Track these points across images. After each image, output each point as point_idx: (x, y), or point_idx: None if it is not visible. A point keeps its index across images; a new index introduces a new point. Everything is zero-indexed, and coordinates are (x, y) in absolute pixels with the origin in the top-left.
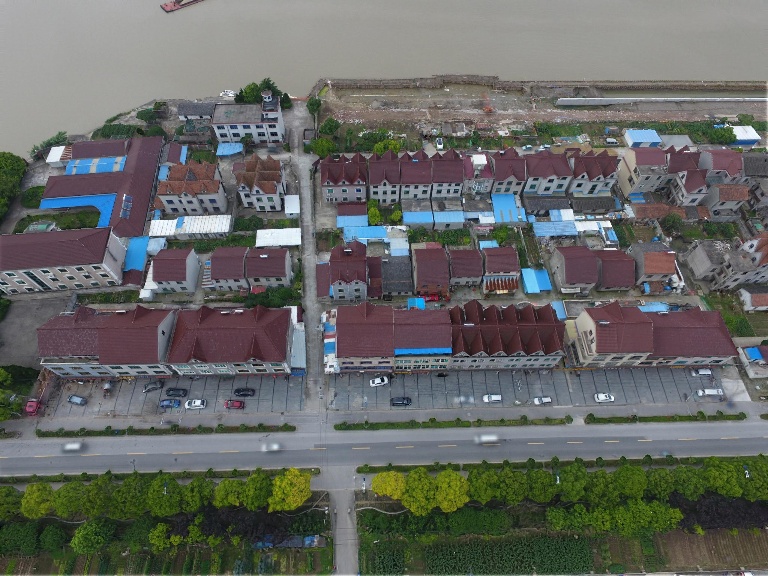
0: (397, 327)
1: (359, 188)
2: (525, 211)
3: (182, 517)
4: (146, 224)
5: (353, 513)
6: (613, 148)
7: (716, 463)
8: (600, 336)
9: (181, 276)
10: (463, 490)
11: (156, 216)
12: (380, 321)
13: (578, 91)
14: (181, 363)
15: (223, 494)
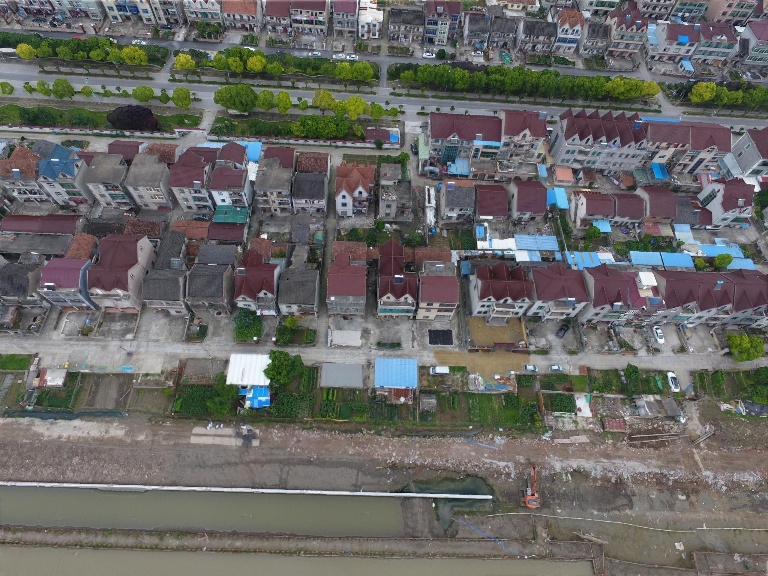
0: None
1: None
2: None
3: None
4: None
5: None
6: (438, 365)
7: (461, 81)
8: None
9: None
10: None
11: None
12: (701, 130)
13: (446, 536)
14: None
15: None
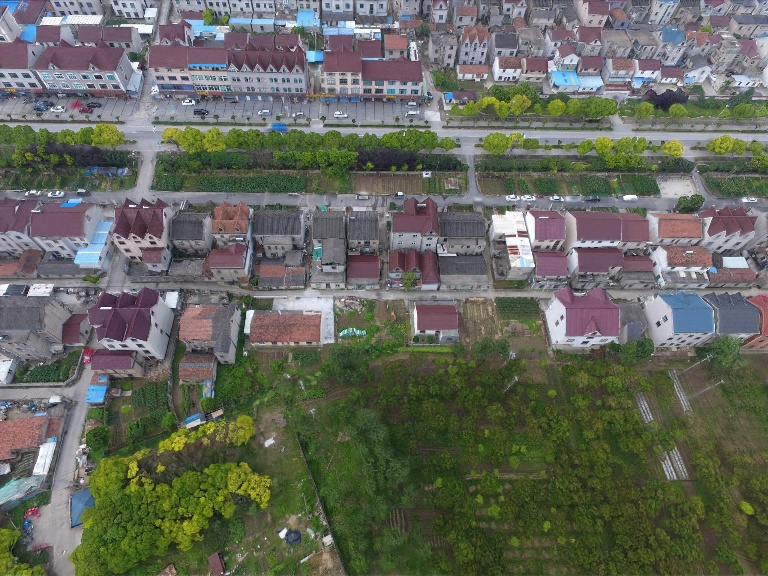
0: (190, 50)
1: (198, 0)
2: (322, 23)
3: (34, 144)
4: (39, 18)
5: (154, 161)
6: None
7: None
8: (326, 61)
9: (56, 39)
10: (221, 139)
11: (48, 16)
12: None
13: None
14: (44, 70)
15: (62, 133)
